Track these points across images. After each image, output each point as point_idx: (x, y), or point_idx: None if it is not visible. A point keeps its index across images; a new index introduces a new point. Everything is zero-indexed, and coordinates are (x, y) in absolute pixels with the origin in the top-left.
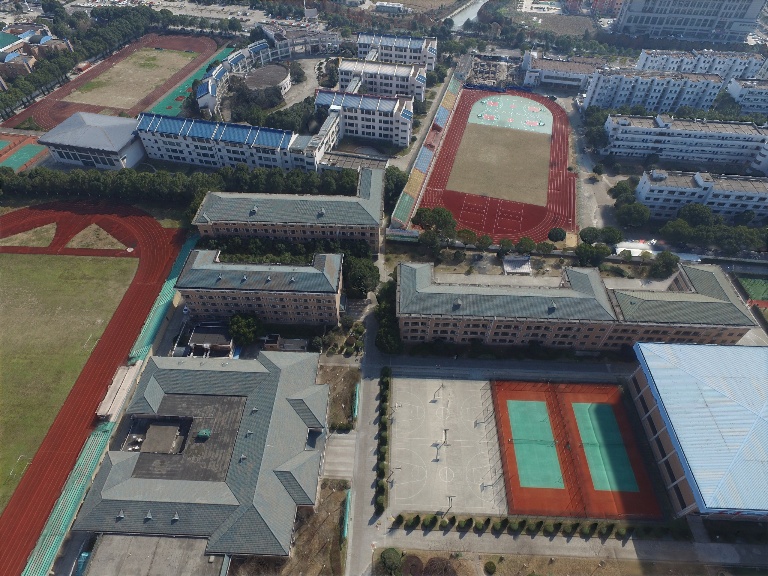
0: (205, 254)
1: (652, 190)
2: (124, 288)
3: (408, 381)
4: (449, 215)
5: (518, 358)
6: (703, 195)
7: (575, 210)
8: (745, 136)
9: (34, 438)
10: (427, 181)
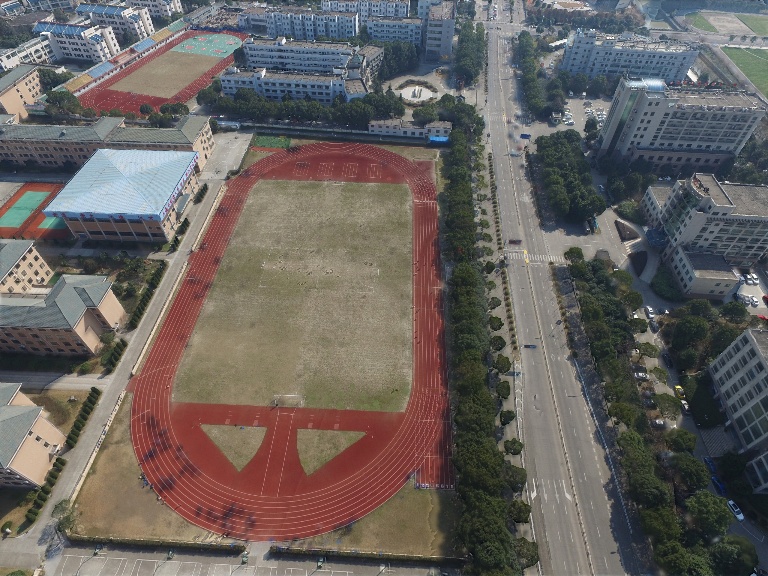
0: None
1: (223, 80)
2: None
3: None
4: (67, 95)
5: (56, 172)
6: (261, 84)
7: (188, 100)
8: (337, 51)
9: None
10: (97, 84)
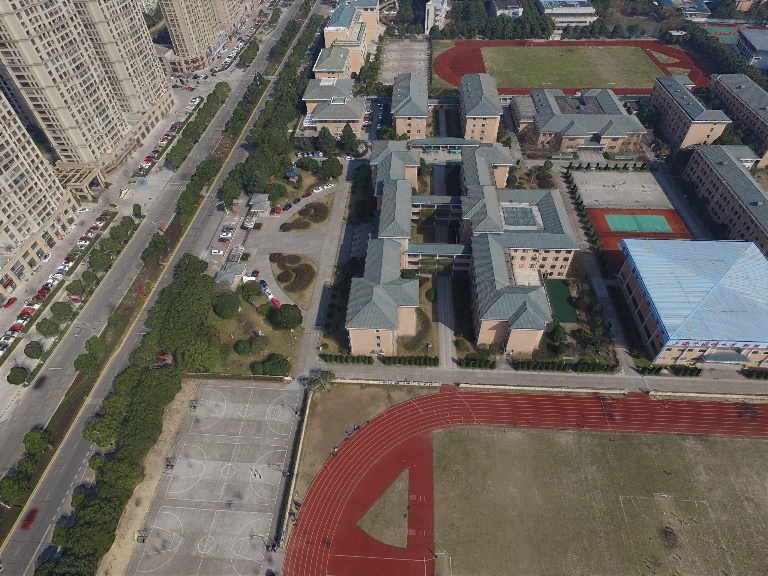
0: (687, 79)
1: None
2: (651, 87)
3: (652, 178)
4: None
5: (705, 224)
6: None
7: None
8: None
9: (559, 86)
10: None
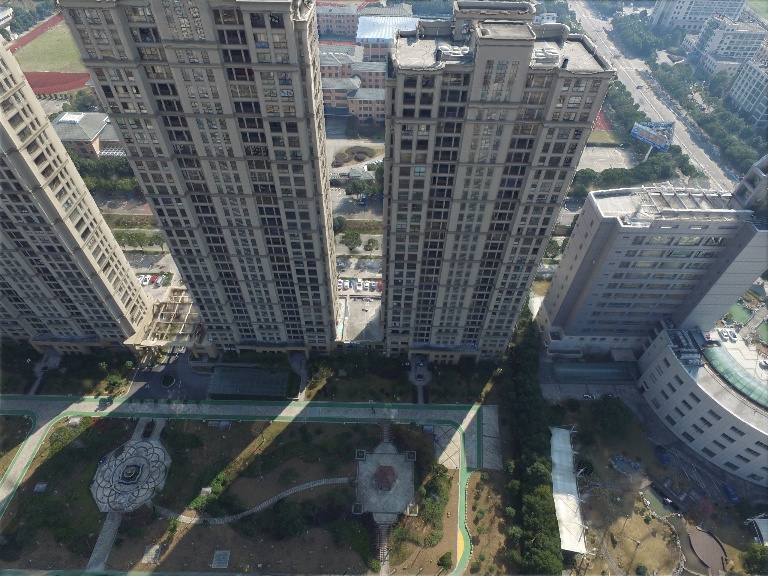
0: None
1: None
2: None
3: None
4: None
5: (321, 36)
6: None
7: None
8: None
9: None
10: None
